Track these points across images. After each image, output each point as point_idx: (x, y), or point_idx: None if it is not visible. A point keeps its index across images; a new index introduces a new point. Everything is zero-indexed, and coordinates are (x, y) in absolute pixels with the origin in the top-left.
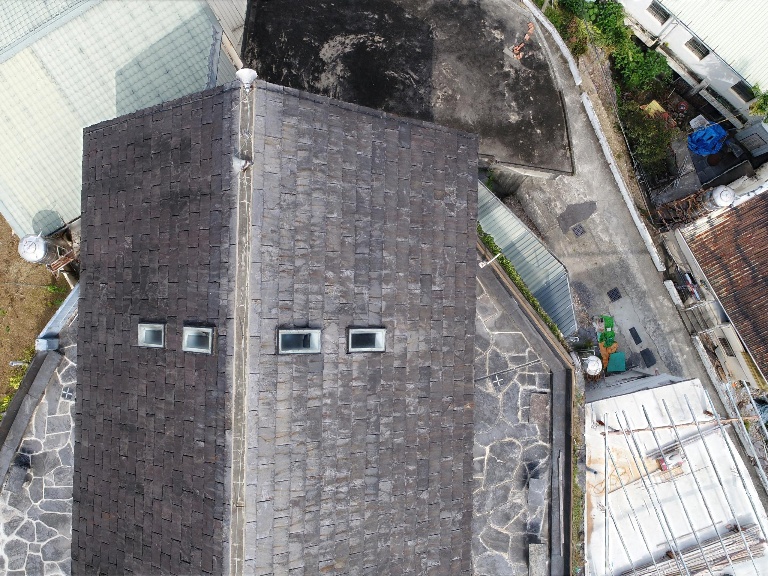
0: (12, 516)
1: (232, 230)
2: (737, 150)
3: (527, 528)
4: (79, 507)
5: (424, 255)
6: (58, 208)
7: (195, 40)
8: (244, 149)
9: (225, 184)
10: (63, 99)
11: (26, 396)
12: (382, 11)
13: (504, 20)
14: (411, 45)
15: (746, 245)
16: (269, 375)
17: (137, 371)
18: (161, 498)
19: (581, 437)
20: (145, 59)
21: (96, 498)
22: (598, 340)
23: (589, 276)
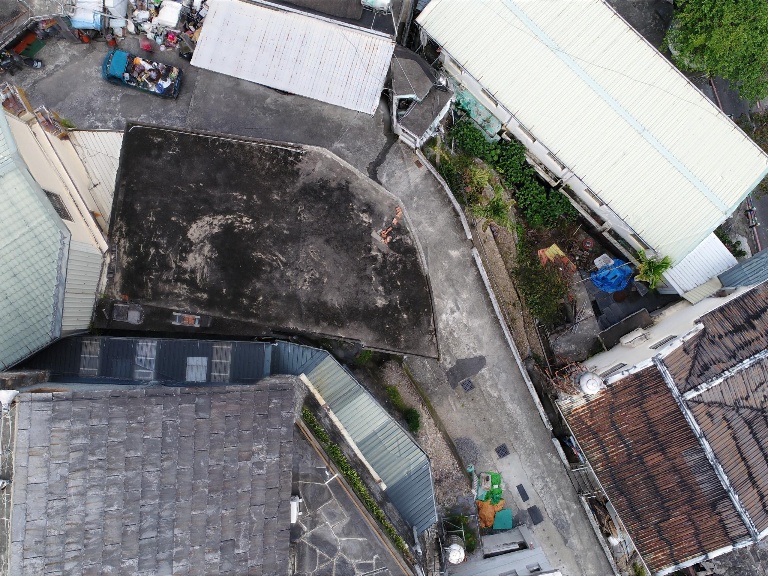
0: None
1: None
2: (642, 289)
3: None
4: None
5: (225, 521)
6: None
7: (42, 245)
8: (5, 465)
9: None
10: None
11: None
12: (251, 192)
13: (372, 203)
14: (279, 227)
15: (621, 422)
16: None
17: None
18: None
19: None
20: None
21: None
22: (483, 499)
23: (477, 432)
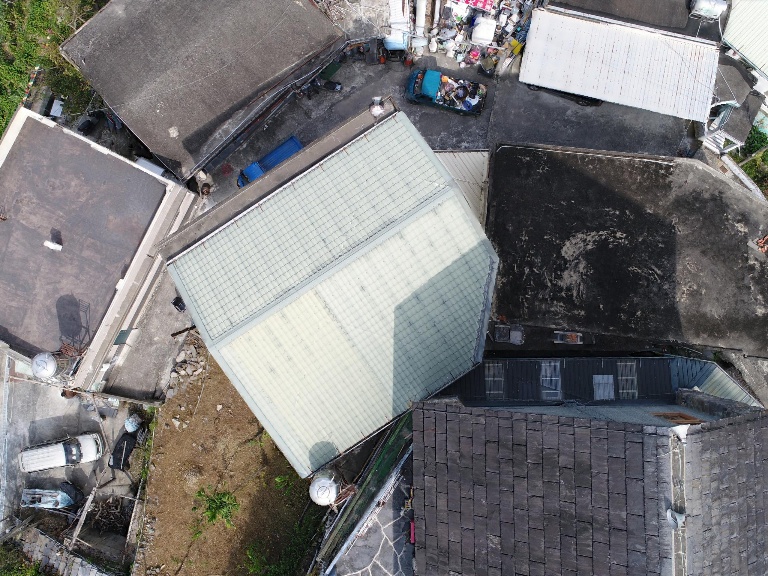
0: None
1: None
2: None
3: None
4: None
5: None
6: (334, 439)
7: (472, 271)
8: (677, 499)
9: (652, 529)
10: (343, 335)
11: None
12: (623, 207)
13: (747, 213)
14: (654, 240)
15: None
16: None
17: None
18: None
19: None
20: (423, 292)
21: None
22: None
23: None
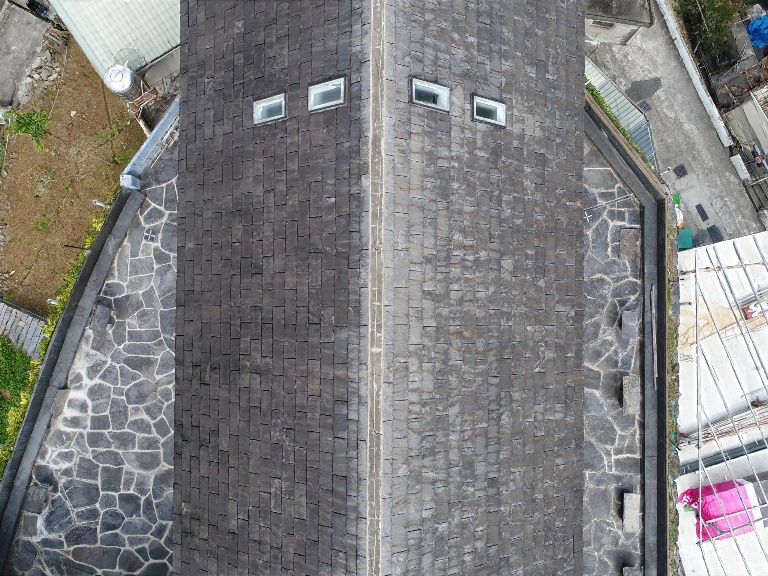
0: (95, 360)
1: None
2: None
3: (618, 365)
4: (184, 310)
5: (538, 40)
6: (140, 46)
7: None
8: None
9: None
10: None
11: (109, 236)
12: None
13: None
14: None
15: None
16: (404, 123)
17: (252, 152)
18: (283, 270)
19: (674, 269)
20: None
21: (204, 295)
22: None
23: None
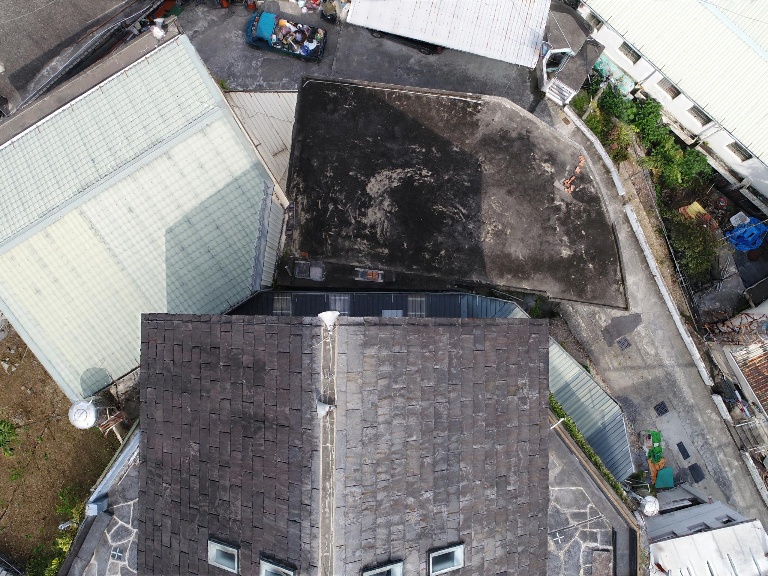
0: None
1: (315, 474)
2: None
3: None
4: None
5: (499, 457)
6: (106, 365)
7: (246, 195)
8: (327, 390)
9: (306, 423)
10: (112, 258)
11: (75, 559)
12: (429, 144)
13: (554, 153)
14: (459, 179)
15: None
16: None
17: None
18: None
19: None
20: (195, 216)
21: None
22: None
23: (635, 390)
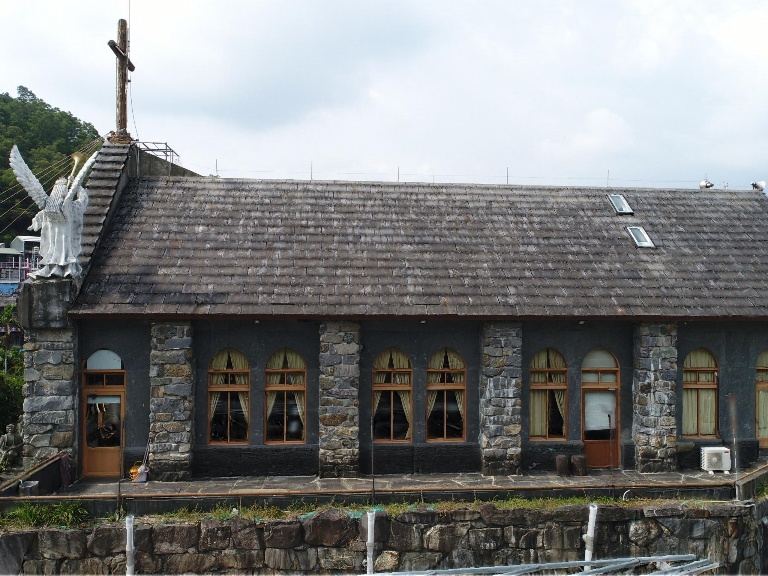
0: None
1: None
2: None
3: None
4: None
5: None
6: None
7: None
8: None
9: None
10: None
11: None
12: None
13: None
14: None
15: None
16: None
17: None
18: None
19: (637, 508)
20: None
21: None
22: None
23: None
